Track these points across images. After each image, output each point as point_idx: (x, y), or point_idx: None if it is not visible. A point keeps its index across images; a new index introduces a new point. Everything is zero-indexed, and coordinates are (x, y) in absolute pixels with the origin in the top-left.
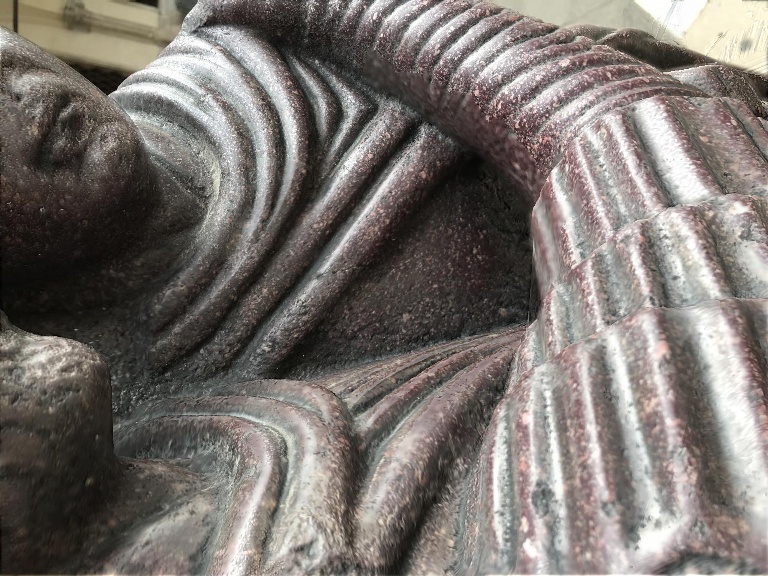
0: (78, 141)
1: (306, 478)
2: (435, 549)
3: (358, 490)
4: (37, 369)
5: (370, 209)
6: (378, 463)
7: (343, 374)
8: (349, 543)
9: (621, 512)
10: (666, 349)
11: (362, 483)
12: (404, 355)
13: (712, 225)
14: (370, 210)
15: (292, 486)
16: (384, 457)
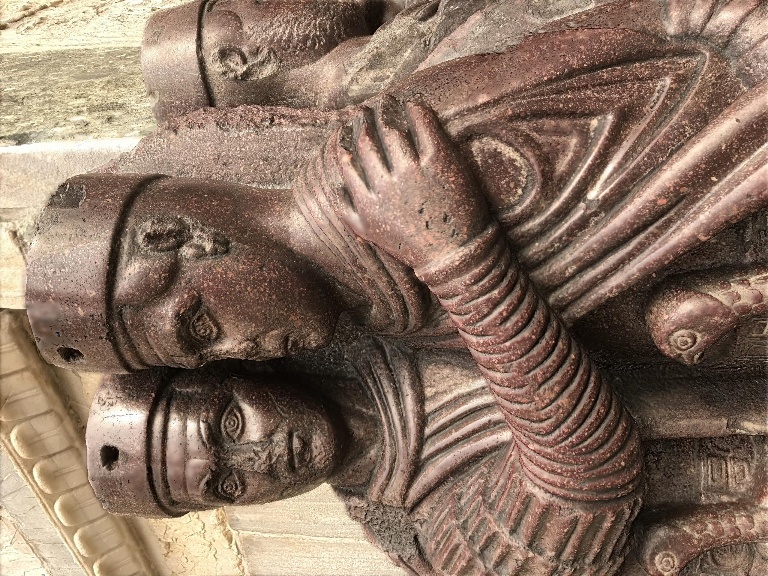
0: (300, 346)
1: (397, 479)
2: (431, 500)
3: (414, 481)
4: (318, 464)
5: (460, 341)
6: (423, 473)
7: (446, 370)
8: (404, 502)
9: (443, 566)
10: (465, 565)
11: (416, 478)
12: (473, 382)
13: (511, 551)
14: (460, 342)
15: (393, 478)
16: (425, 473)
